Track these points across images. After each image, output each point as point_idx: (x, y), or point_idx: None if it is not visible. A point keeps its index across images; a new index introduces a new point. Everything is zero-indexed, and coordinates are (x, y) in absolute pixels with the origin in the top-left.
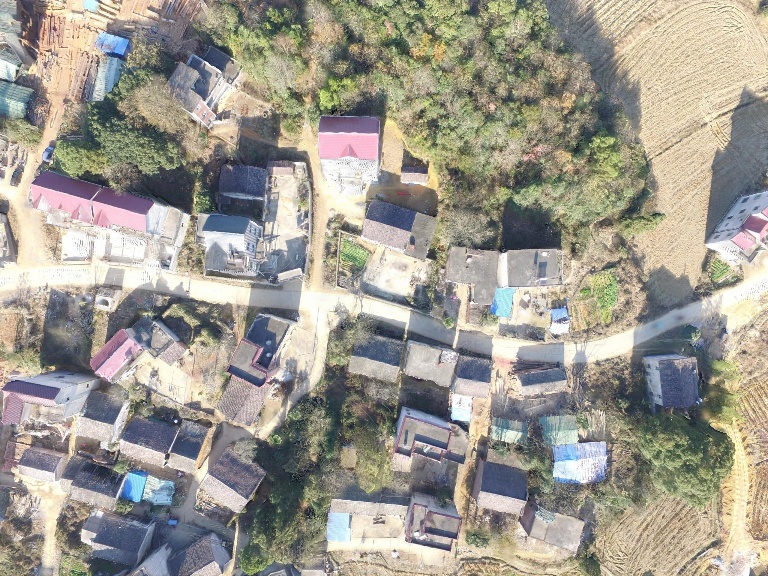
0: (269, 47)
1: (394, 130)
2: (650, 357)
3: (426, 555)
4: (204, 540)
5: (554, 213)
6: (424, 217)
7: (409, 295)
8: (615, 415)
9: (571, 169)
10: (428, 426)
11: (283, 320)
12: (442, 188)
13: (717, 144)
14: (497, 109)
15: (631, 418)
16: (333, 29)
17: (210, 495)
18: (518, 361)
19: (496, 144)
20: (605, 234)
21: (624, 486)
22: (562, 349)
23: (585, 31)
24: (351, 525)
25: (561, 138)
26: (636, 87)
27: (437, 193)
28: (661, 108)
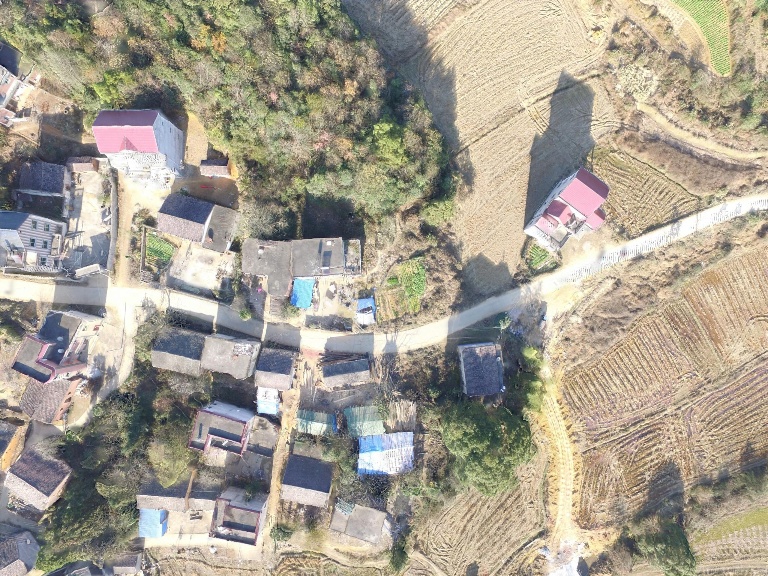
0: (46, 42)
1: (198, 123)
2: (462, 346)
3: (244, 550)
4: (8, 538)
5: (351, 202)
6: (222, 209)
7: (216, 288)
8: (425, 405)
9: (353, 157)
10: (222, 419)
11: (76, 316)
12: (239, 180)
13: (536, 129)
14: (279, 98)
15: (440, 408)
16: (111, 23)
17: (15, 493)
18: (326, 352)
19: (286, 134)
20: (411, 222)
21: (433, 476)
22: (372, 339)
23: (398, 19)
24: (168, 521)
25: (345, 126)
26: (451, 74)
27: (236, 185)
28: (477, 94)
